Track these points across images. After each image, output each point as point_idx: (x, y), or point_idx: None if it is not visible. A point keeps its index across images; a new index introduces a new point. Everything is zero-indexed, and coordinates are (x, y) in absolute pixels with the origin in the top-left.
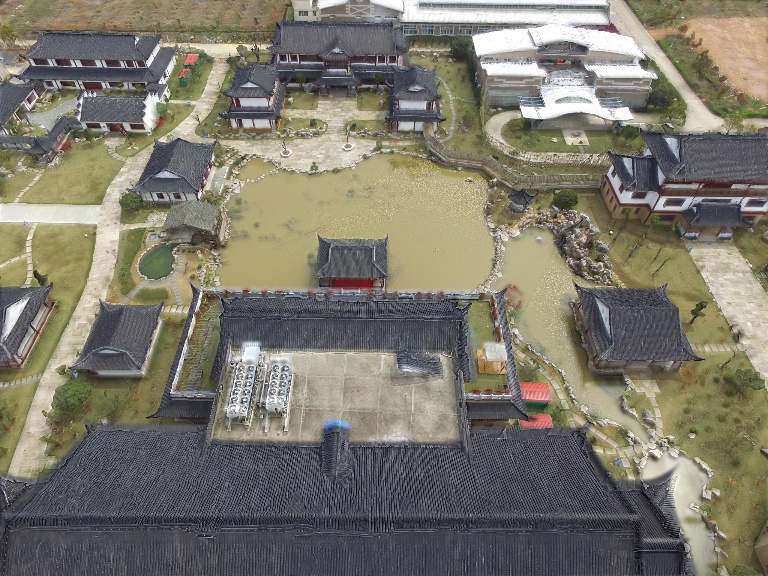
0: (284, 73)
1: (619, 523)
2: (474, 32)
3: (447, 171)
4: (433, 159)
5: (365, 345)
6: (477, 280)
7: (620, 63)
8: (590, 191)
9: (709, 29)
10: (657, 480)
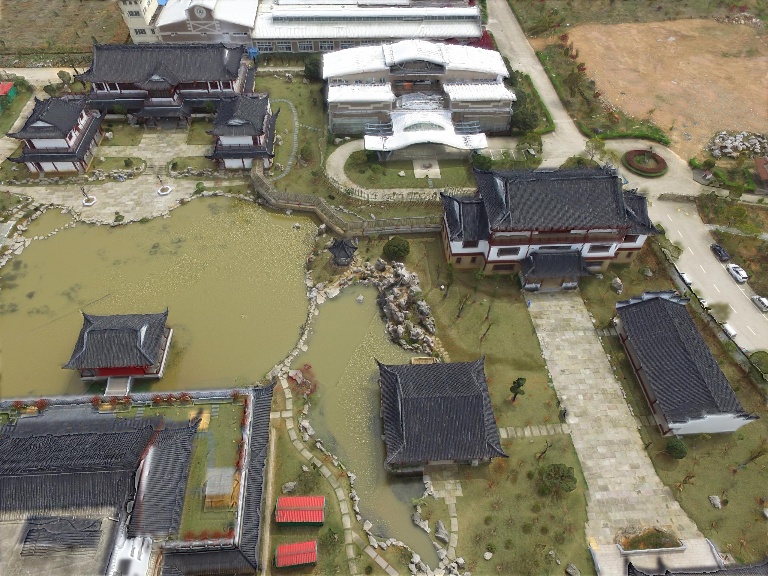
0: (103, 104)
1: None
2: (336, 47)
3: (276, 215)
4: (260, 202)
5: (4, 511)
6: (280, 355)
7: (482, 82)
8: (430, 235)
9: (593, 37)
10: None
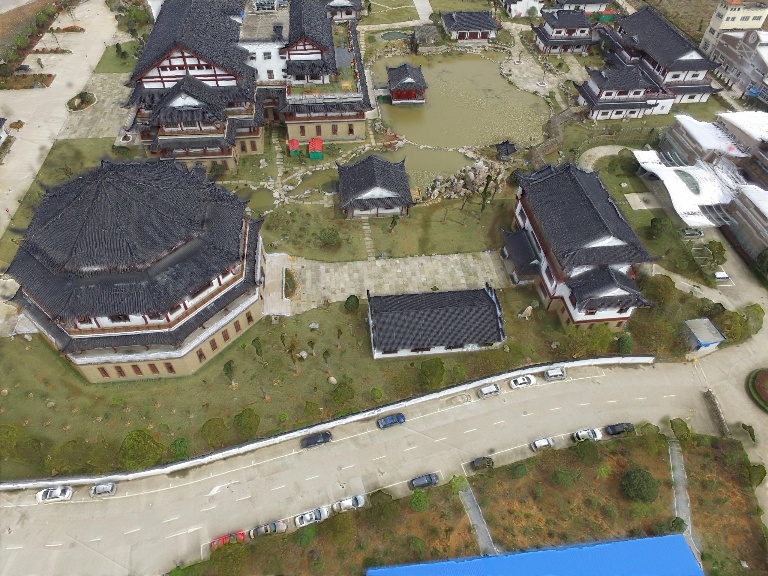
0: (611, 40)
1: (181, 39)
2: None
3: None
4: None
5: None
6: None
7: None
8: None
9: None
10: (260, 194)
